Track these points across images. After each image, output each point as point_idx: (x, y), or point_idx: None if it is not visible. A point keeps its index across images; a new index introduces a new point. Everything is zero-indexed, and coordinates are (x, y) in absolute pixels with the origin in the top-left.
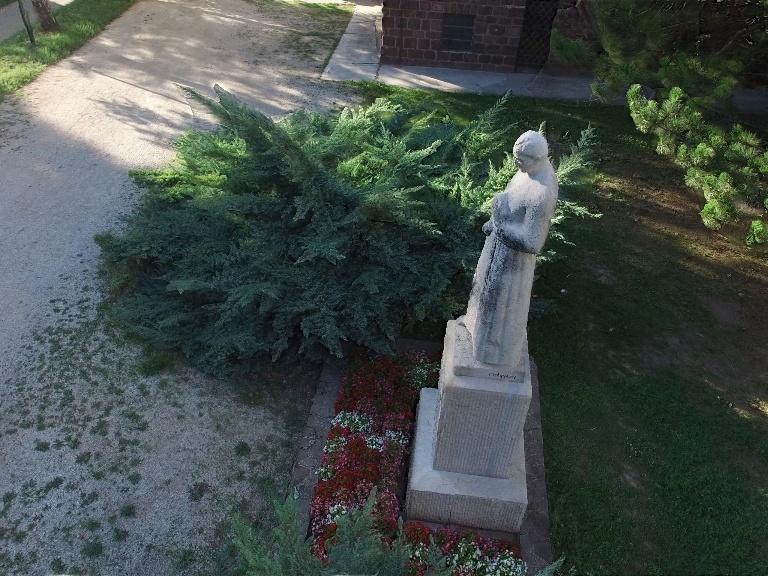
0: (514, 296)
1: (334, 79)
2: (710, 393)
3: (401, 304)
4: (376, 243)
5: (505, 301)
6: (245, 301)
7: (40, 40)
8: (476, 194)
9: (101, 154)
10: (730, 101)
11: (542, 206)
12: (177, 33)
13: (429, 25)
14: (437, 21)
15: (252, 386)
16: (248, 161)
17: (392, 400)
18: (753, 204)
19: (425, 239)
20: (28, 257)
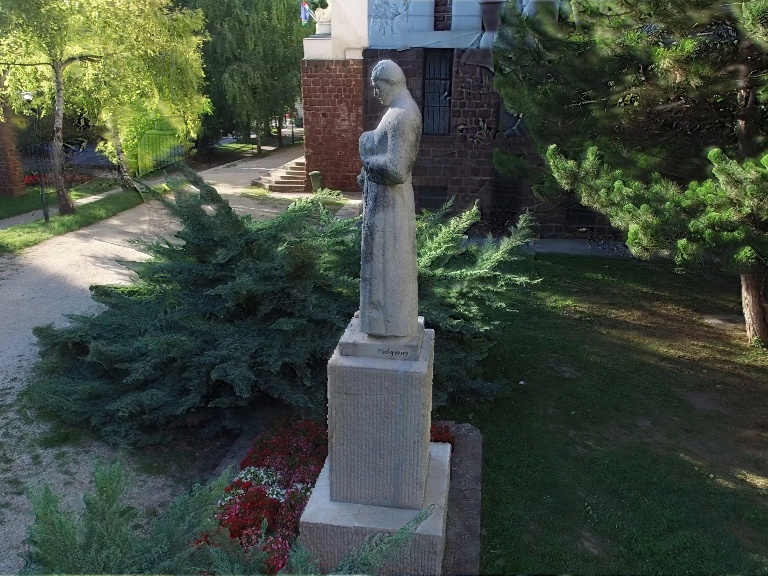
0: (389, 240)
1: None
2: (686, 465)
3: None
4: (300, 295)
5: (380, 247)
6: (153, 346)
7: (54, 220)
8: None
9: (76, 289)
10: None
11: (399, 124)
12: None
13: None
14: None
15: (159, 458)
16: (186, 235)
17: None
18: (681, 235)
19: None
20: None
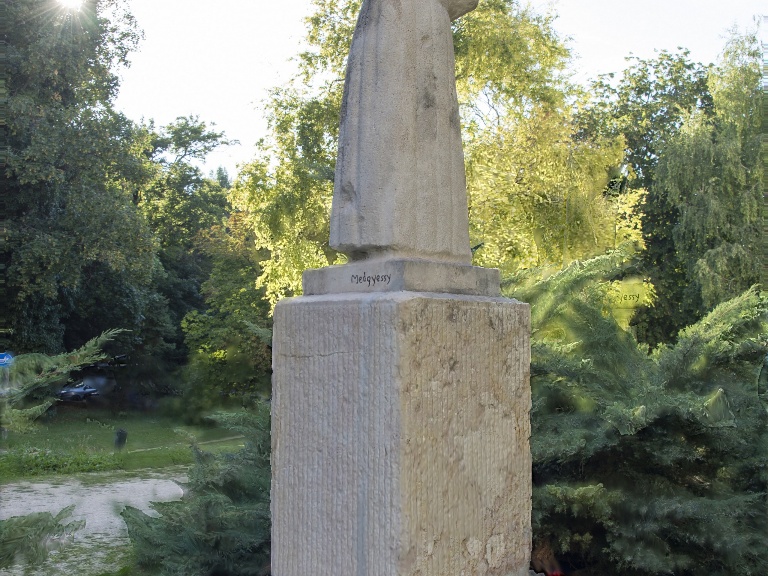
0: (368, 76)
1: None
2: None
3: None
4: None
5: (356, 90)
6: (226, 417)
7: None
8: None
9: None
10: None
11: None
12: None
13: None
14: None
15: None
16: None
17: None
18: None
19: (604, 426)
20: None
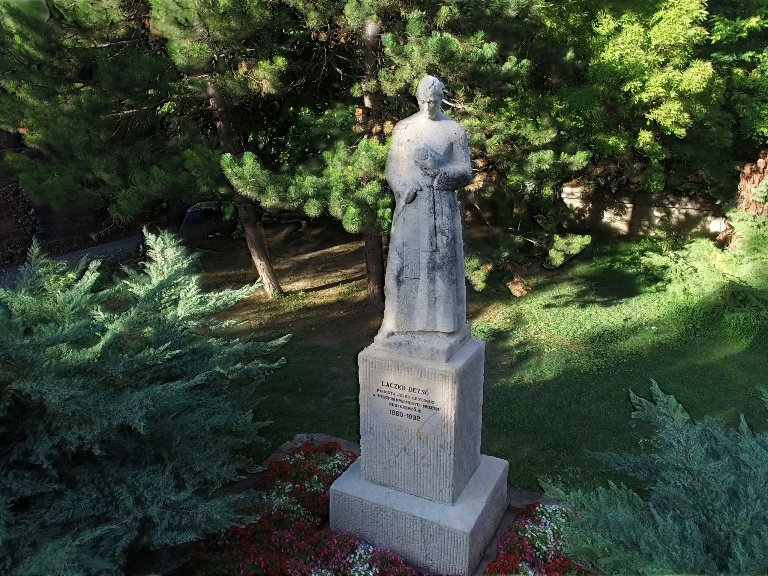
0: None
1: None
2: None
3: None
4: None
5: None
6: (71, 575)
7: None
8: None
9: None
10: None
11: None
12: None
13: None
14: None
15: None
16: None
17: None
18: None
19: None
20: None
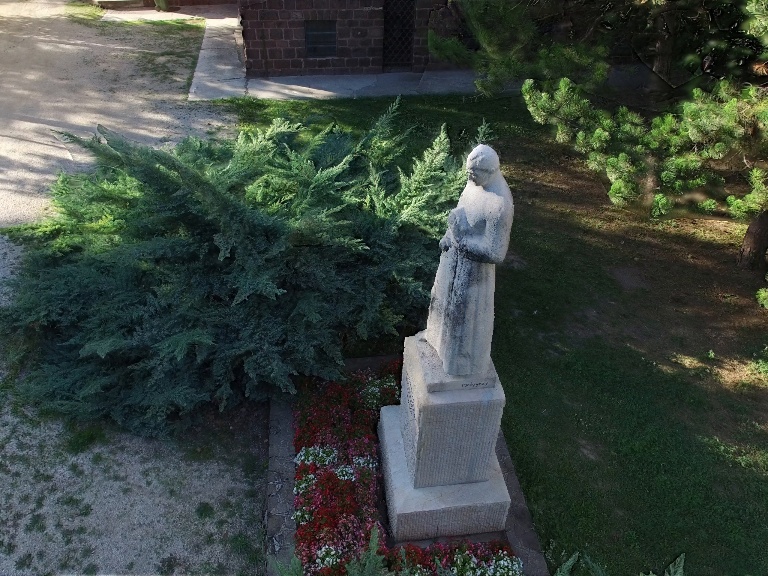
0: (481, 307)
1: (202, 99)
2: (635, 356)
3: (338, 325)
4: (306, 269)
5: (473, 313)
6: (180, 354)
7: None
8: (391, 203)
9: None
10: (606, 84)
11: (503, 217)
12: (13, 67)
13: (291, 34)
14: (299, 29)
15: (197, 440)
16: (150, 203)
17: (350, 425)
18: (650, 179)
19: (349, 255)
20: None
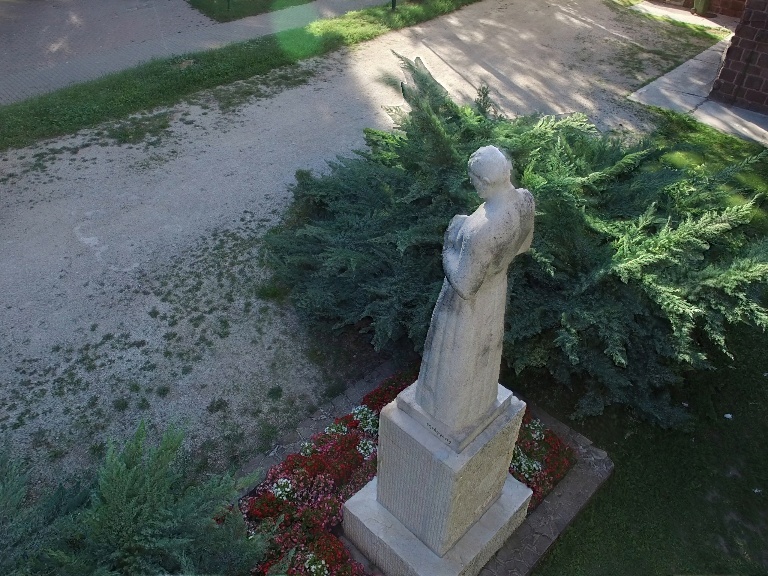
0: (448, 342)
1: (641, 101)
2: None
3: None
4: None
5: (439, 344)
6: (331, 262)
7: (400, 8)
8: None
9: (373, 111)
10: None
11: (471, 241)
12: (519, 25)
13: None
14: None
15: (326, 346)
16: (414, 138)
17: None
18: None
19: None
20: (258, 173)
